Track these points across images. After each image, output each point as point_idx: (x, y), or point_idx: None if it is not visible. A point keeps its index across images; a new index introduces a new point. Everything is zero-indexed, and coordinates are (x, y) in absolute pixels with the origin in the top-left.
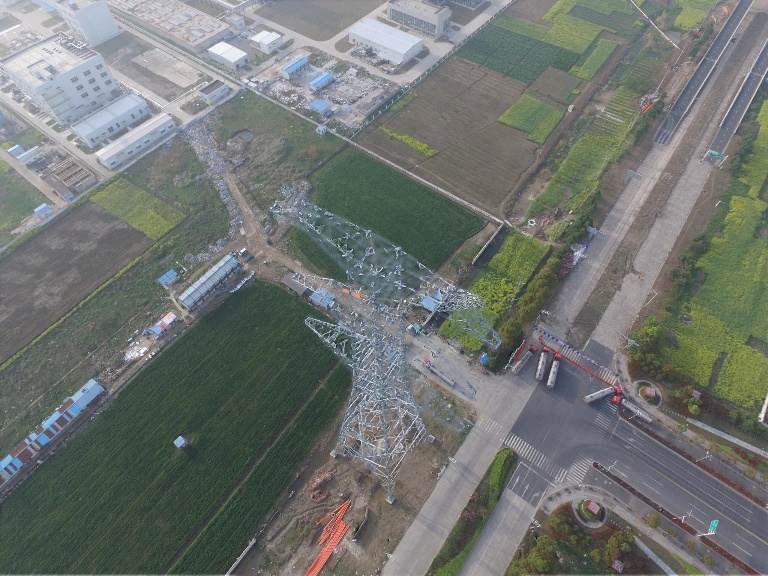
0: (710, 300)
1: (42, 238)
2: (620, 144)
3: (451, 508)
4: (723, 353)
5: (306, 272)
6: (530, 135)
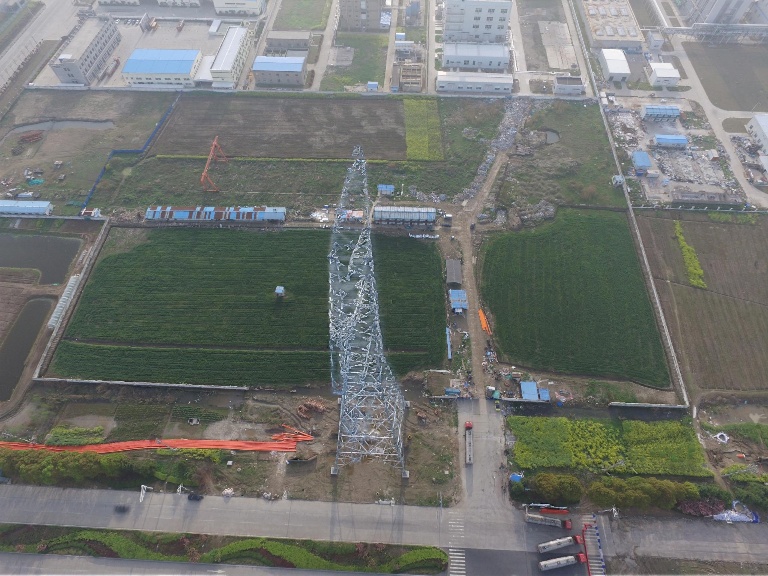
0: None
1: (355, 103)
2: None
3: (359, 530)
4: None
5: (471, 271)
6: None
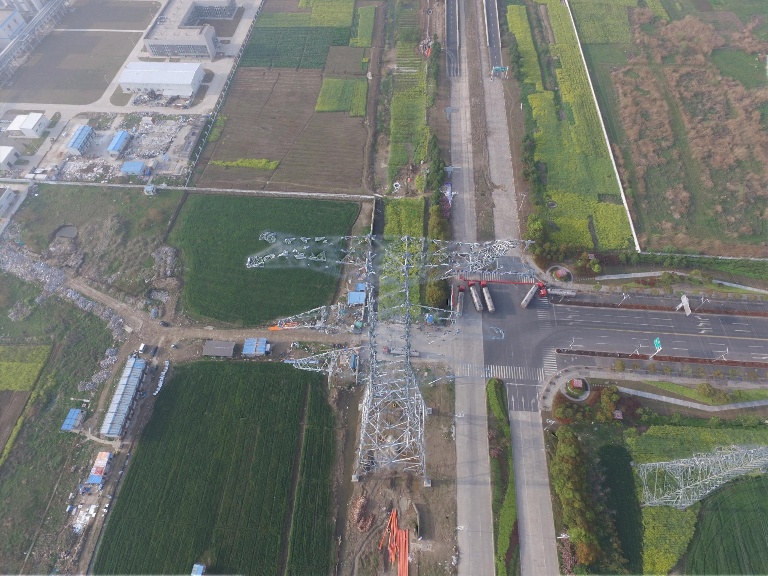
0: (559, 182)
1: None
2: (426, 90)
3: (479, 456)
4: (589, 217)
5: (222, 332)
6: (350, 112)
